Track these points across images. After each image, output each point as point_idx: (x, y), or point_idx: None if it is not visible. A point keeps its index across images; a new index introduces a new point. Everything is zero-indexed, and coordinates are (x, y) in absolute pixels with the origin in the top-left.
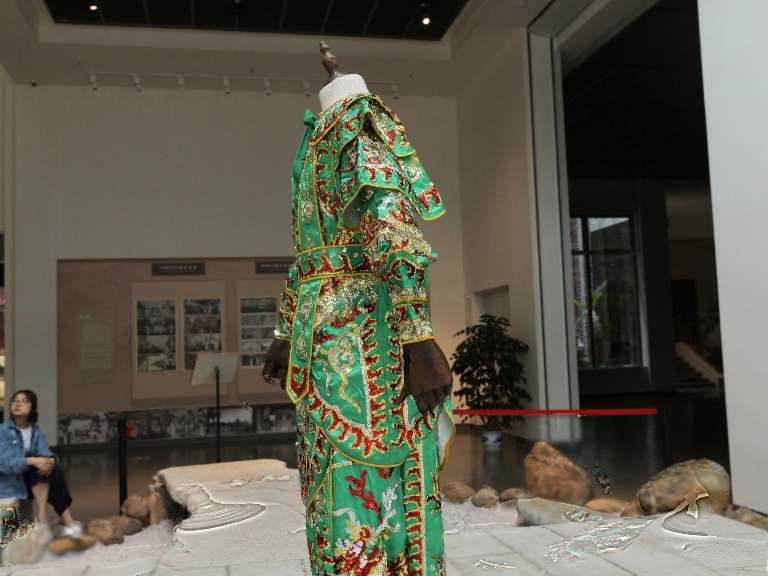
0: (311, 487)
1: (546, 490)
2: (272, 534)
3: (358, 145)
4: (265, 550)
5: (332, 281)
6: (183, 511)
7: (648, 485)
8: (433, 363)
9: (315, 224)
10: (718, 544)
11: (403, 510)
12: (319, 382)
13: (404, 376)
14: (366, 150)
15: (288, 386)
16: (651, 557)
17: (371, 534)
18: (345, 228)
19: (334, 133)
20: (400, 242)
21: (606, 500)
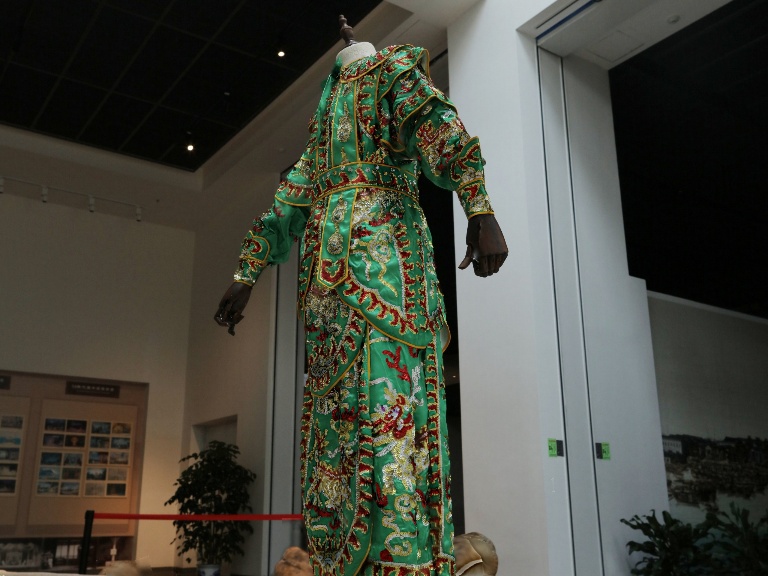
0: (341, 366)
1: None
2: None
3: (414, 74)
4: None
5: (366, 191)
6: None
7: None
8: (497, 233)
9: (352, 143)
10: None
11: (425, 389)
12: (358, 270)
13: (471, 242)
14: (423, 78)
15: (319, 277)
16: None
17: (406, 401)
18: (389, 143)
19: (380, 69)
20: (464, 142)
21: None
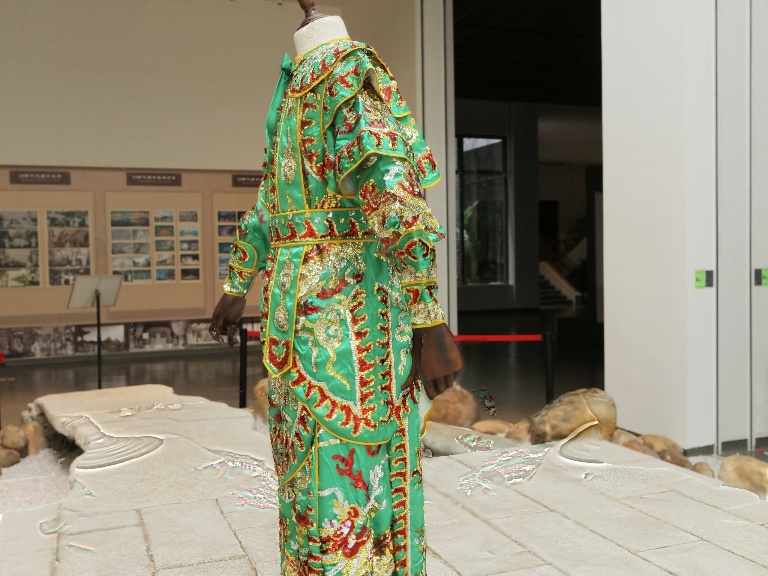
0: (292, 465)
1: (435, 413)
2: (178, 471)
3: (358, 104)
4: (174, 490)
5: (316, 248)
6: (70, 443)
7: (543, 413)
8: (446, 348)
9: (298, 185)
10: (614, 472)
11: (389, 486)
12: (304, 357)
13: (413, 361)
14: (368, 111)
15: (266, 359)
16: (557, 487)
17: (359, 513)
18: (336, 193)
19: (324, 86)
20: (410, 217)
21: (491, 422)
